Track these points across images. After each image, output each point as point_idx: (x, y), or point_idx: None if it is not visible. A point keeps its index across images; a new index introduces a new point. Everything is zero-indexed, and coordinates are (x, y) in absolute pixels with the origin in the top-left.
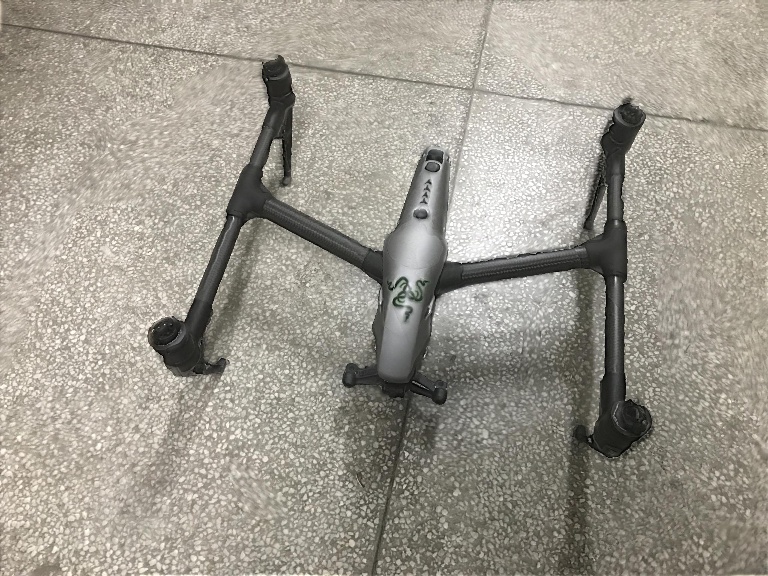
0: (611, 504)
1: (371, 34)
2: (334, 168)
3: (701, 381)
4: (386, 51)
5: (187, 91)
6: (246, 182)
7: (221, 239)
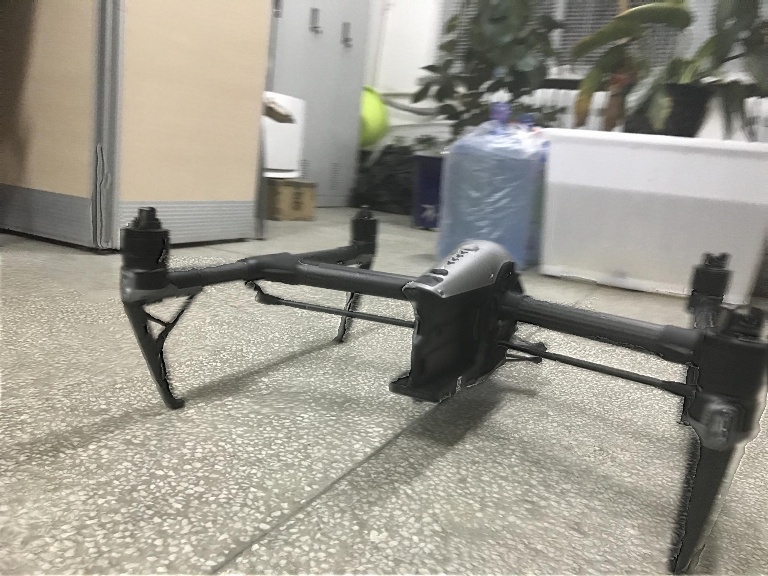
0: None
1: None
2: (575, 570)
3: None
4: None
5: None
6: None
7: None
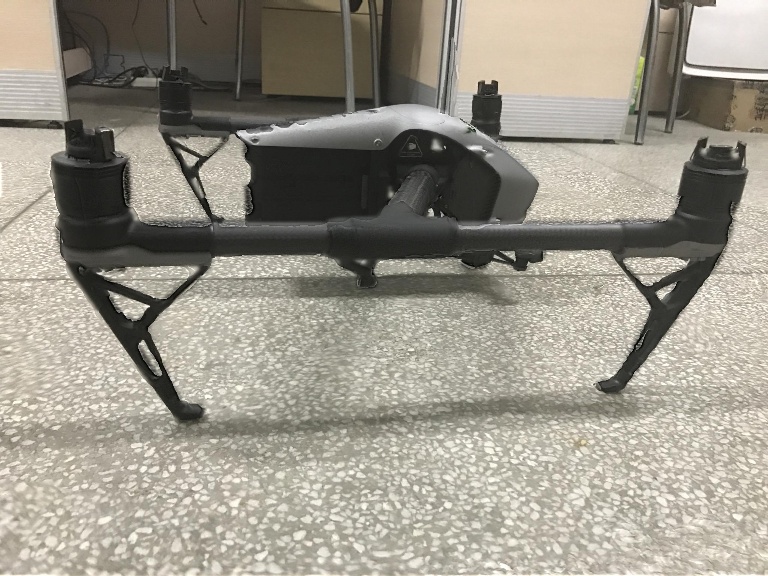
0: None
1: None
2: None
3: None
4: None
5: None
6: None
7: None
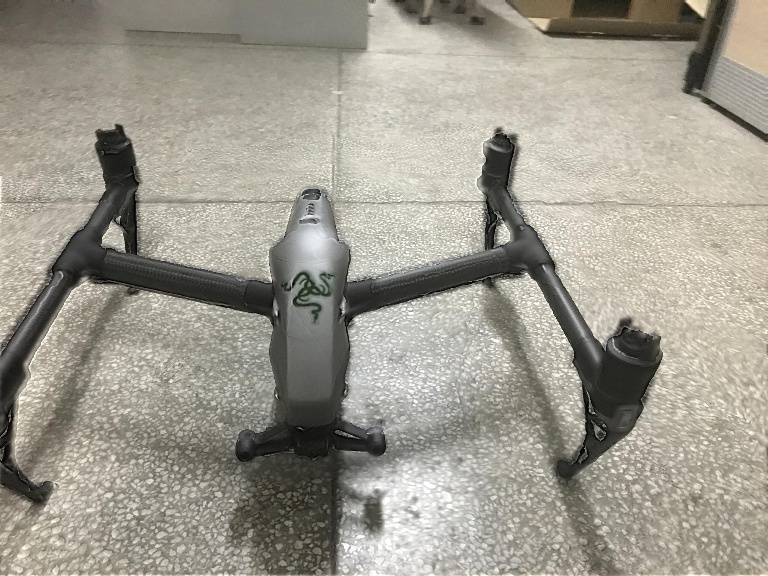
0: (638, 543)
1: (217, 176)
2: None
3: (667, 393)
4: (235, 185)
5: (2, 232)
6: (79, 243)
7: (44, 294)
